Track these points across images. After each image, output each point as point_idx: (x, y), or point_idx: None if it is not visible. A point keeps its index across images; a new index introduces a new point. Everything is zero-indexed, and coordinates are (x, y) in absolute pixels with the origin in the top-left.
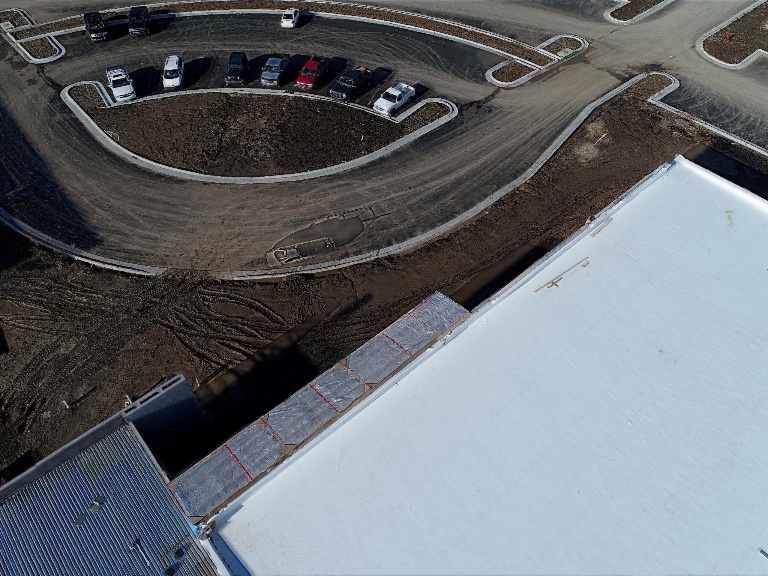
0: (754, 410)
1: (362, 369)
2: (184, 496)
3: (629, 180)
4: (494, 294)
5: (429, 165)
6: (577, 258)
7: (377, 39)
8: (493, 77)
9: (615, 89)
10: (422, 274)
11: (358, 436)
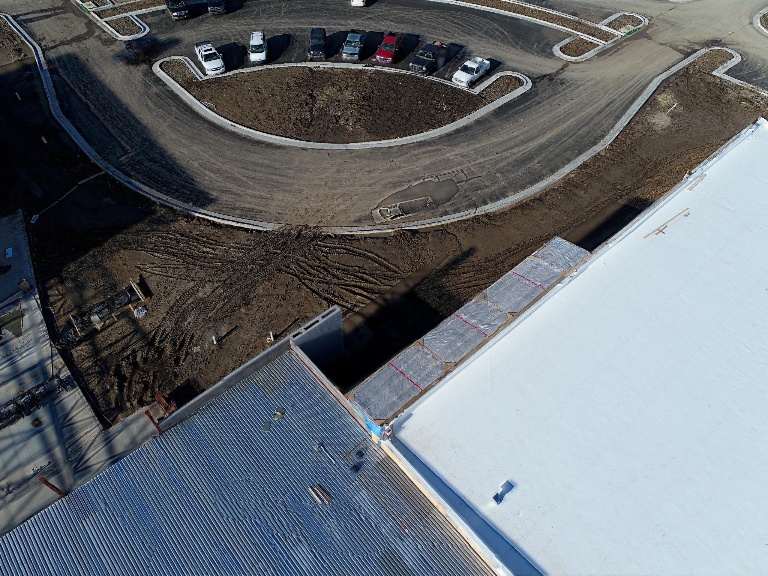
0: None
1: (501, 301)
2: (363, 404)
3: (704, 146)
4: (610, 238)
5: (511, 132)
6: (678, 209)
7: (444, 17)
8: (561, 52)
9: (679, 63)
10: (520, 229)
11: (504, 358)
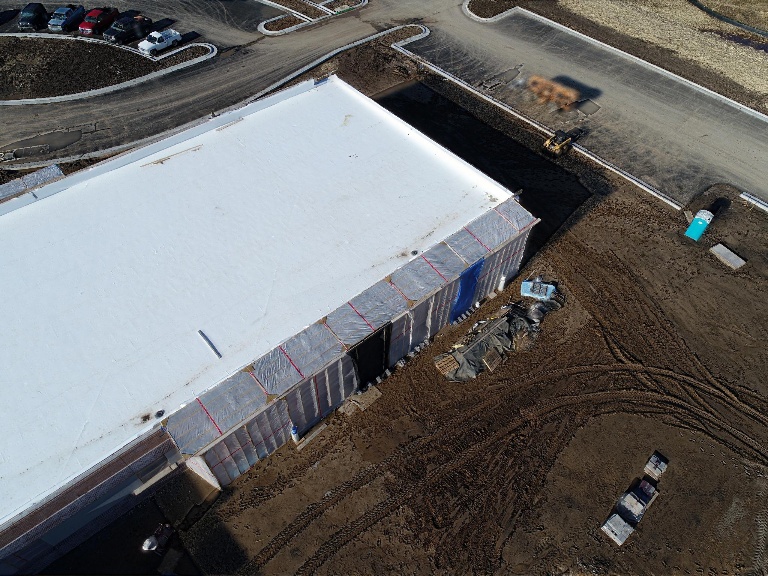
0: (263, 246)
1: None
2: None
3: None
4: (94, 164)
5: (165, 93)
6: (193, 145)
7: None
8: (263, 27)
9: (368, 37)
10: None
11: None
